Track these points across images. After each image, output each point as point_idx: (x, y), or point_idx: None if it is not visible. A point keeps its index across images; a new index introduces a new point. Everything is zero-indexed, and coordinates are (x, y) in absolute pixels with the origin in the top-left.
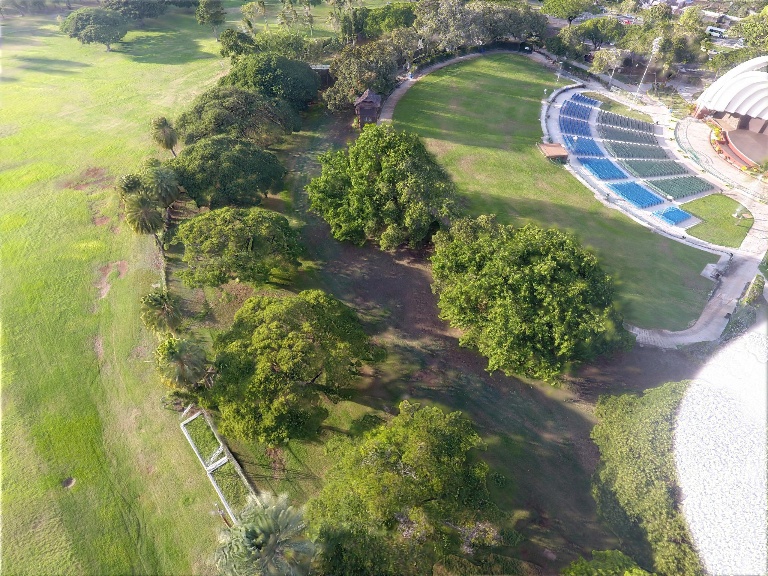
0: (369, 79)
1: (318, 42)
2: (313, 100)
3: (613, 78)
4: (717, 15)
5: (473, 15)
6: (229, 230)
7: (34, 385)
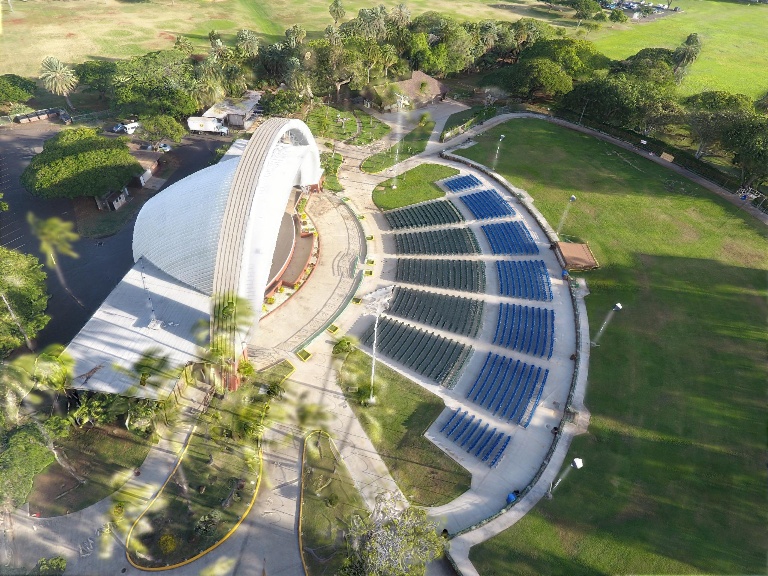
0: None
1: None
2: None
3: None
4: None
5: None
6: None
7: None
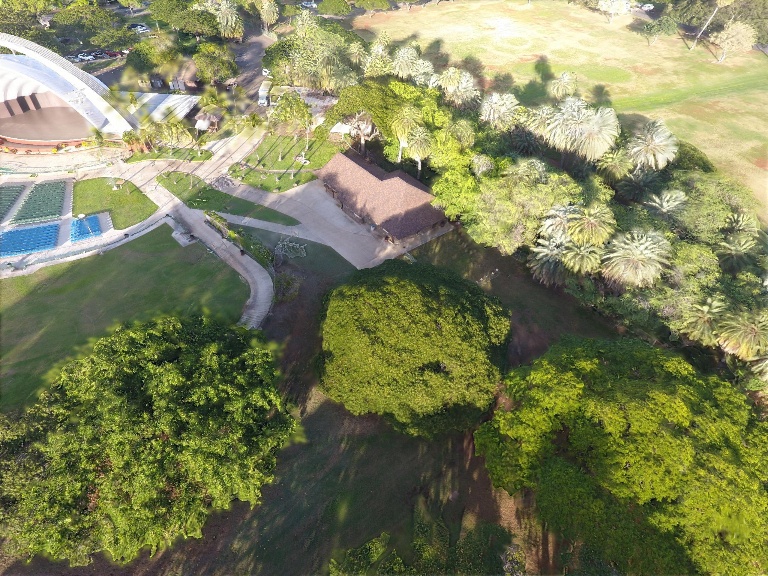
0: None
1: None
2: None
3: None
4: None
5: None
6: None
7: None
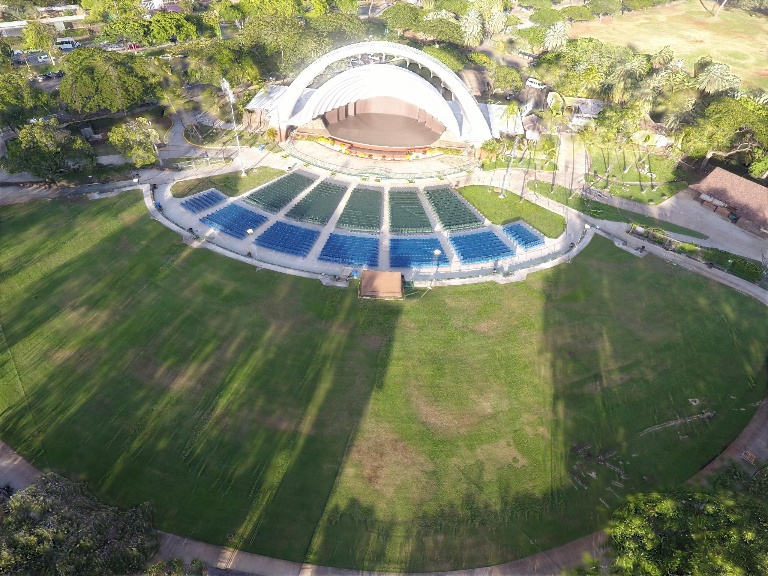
0: None
1: None
2: None
3: None
4: (18, 24)
5: None
6: None
7: None
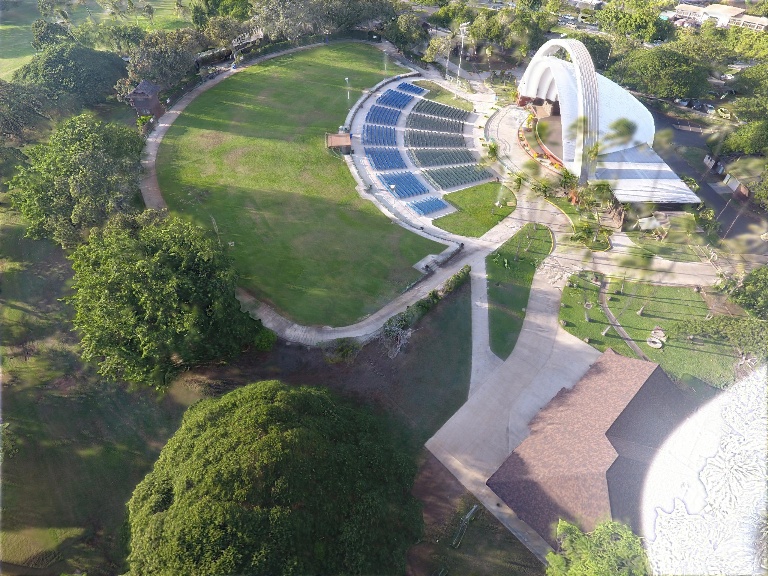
0: (143, 69)
1: (160, 33)
2: (113, 93)
3: (458, 66)
4: (596, 2)
5: (306, 3)
6: None
7: None
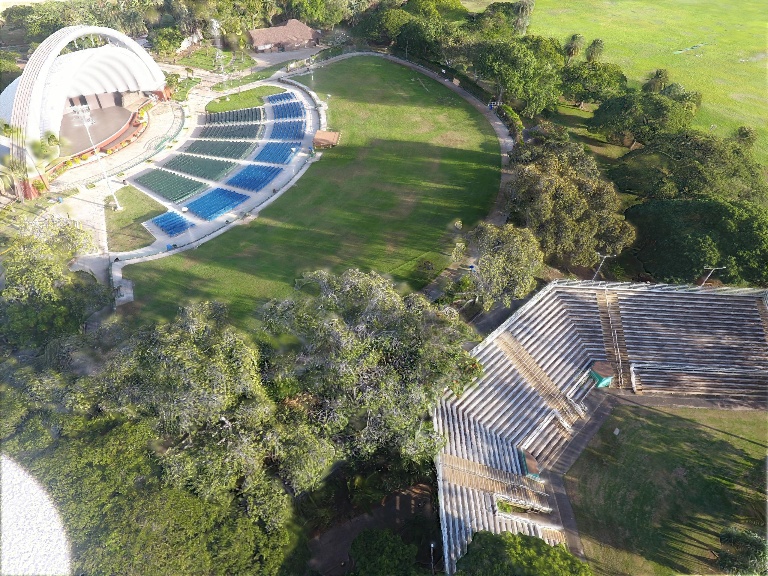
0: None
1: None
2: None
3: None
4: None
5: None
6: (590, 61)
7: (640, 86)
